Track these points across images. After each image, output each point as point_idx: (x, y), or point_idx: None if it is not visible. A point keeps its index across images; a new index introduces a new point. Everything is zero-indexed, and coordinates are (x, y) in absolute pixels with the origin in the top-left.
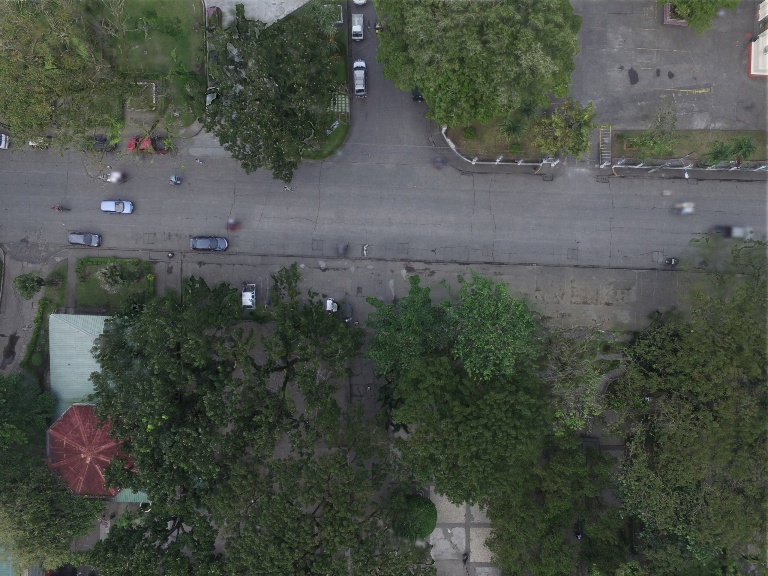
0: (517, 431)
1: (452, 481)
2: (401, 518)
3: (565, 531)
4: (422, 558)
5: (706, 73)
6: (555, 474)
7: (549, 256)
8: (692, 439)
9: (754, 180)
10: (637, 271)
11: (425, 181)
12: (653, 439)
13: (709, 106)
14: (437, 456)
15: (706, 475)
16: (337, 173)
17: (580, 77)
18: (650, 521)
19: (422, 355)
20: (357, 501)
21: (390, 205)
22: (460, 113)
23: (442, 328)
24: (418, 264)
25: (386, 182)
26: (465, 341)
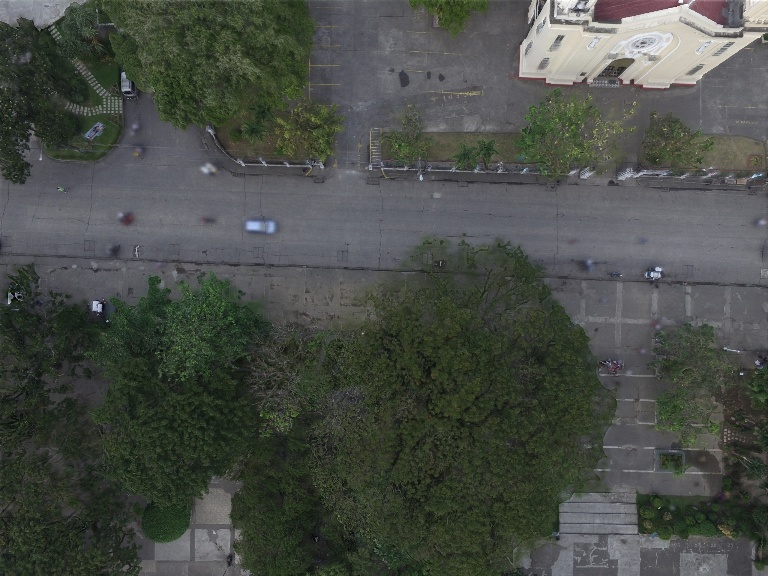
0: (204, 432)
1: (146, 482)
2: (107, 519)
3: (303, 533)
4: (126, 559)
5: (477, 76)
6: (290, 476)
7: (319, 258)
8: (356, 441)
9: (524, 183)
10: (406, 273)
11: (197, 182)
12: (331, 441)
13: (479, 109)
14: (126, 457)
15: (371, 478)
16: (110, 174)
17: (351, 79)
18: (346, 524)
19: (134, 356)
20: (51, 501)
21: (161, 206)
22: (183, 115)
23: (157, 329)
24: (189, 265)
25: (158, 183)
26: (170, 342)
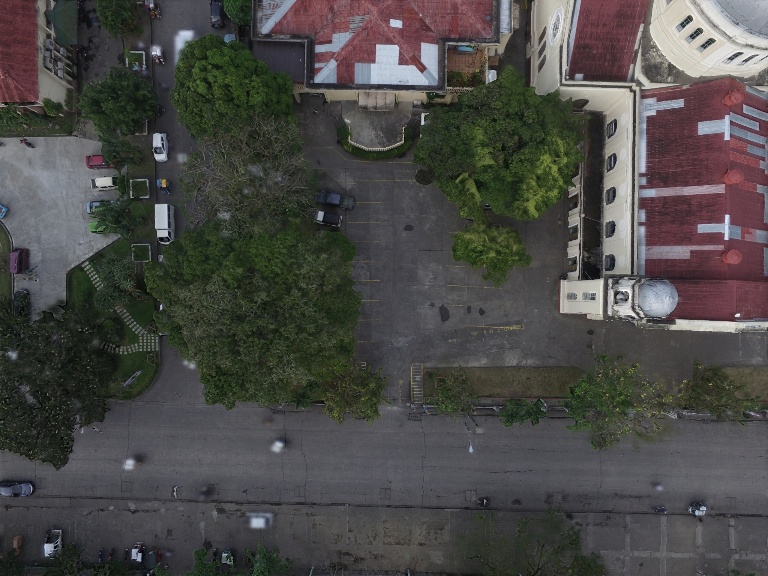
0: None
1: None
2: None
3: None
4: None
5: (517, 309)
6: None
7: (361, 496)
8: None
9: (566, 417)
10: (450, 511)
11: (236, 421)
12: None
13: (520, 343)
14: None
15: None
16: (147, 413)
17: (391, 315)
18: None
19: None
20: None
21: (200, 446)
22: (231, 401)
23: None
24: (229, 505)
25: (196, 422)
26: None
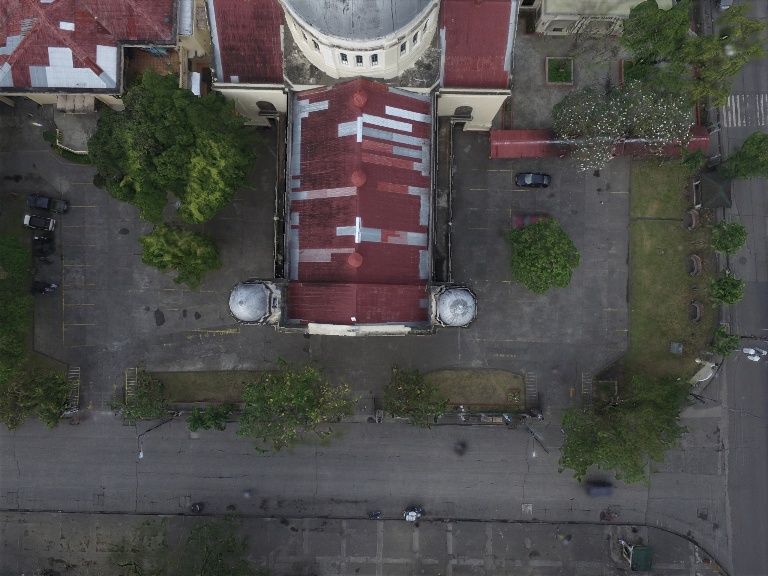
0: None
1: None
2: None
3: None
4: None
5: None
6: None
7: (74, 502)
8: None
9: None
10: None
11: None
12: None
13: (236, 347)
14: None
15: None
16: None
17: (105, 319)
18: None
19: None
20: None
21: None
22: None
23: None
24: None
25: None
26: None
